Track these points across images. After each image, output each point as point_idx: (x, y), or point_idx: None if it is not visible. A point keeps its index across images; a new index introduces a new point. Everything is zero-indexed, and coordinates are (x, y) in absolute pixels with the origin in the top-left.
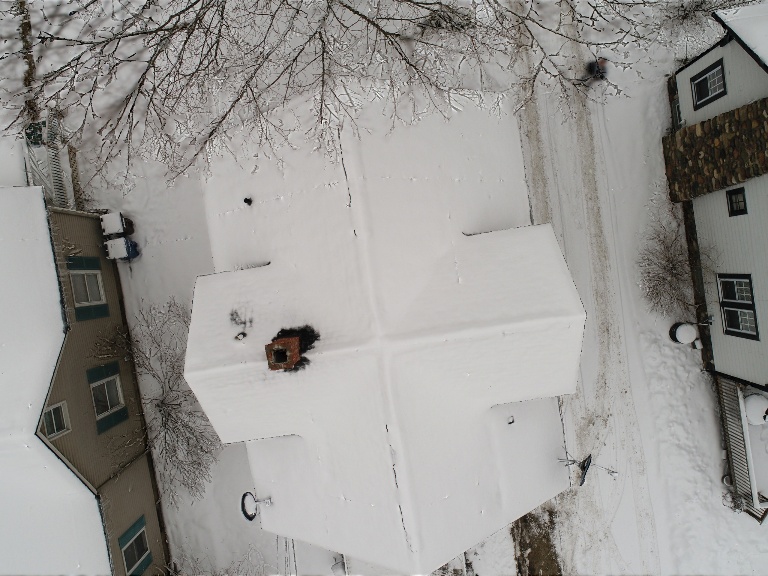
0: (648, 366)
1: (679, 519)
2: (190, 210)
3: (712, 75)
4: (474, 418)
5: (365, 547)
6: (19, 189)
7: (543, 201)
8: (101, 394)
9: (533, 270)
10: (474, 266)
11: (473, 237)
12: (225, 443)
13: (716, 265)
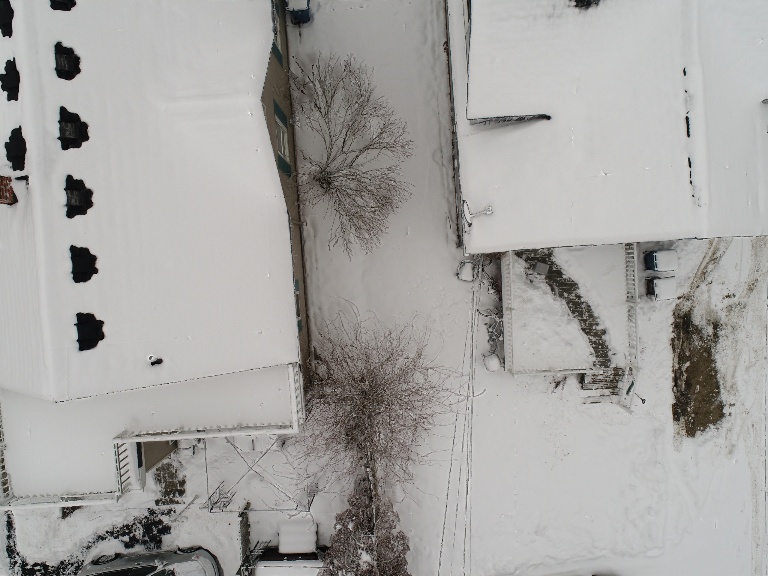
0: None
1: None
2: None
3: None
4: (748, 104)
5: (628, 220)
6: None
7: None
8: None
9: None
10: None
11: None
12: (470, 118)
13: None
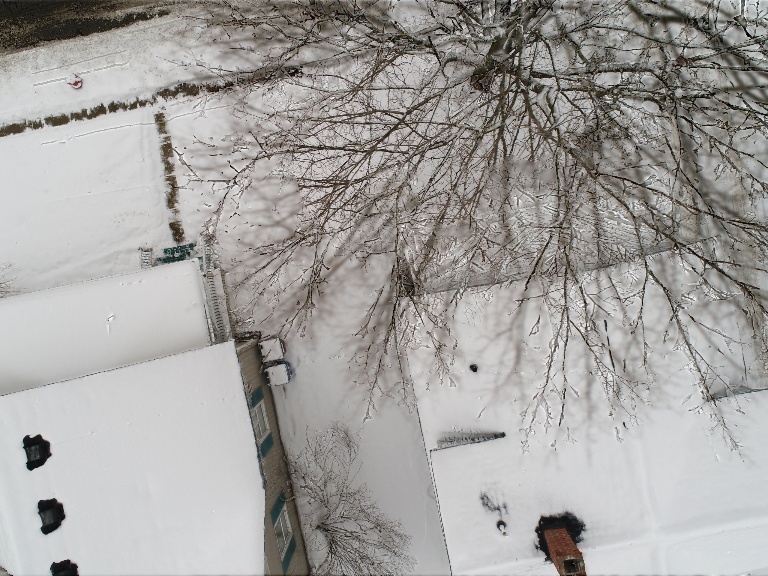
0: None
1: None
2: (343, 328)
3: None
4: None
5: None
6: (216, 347)
7: None
8: (277, 529)
9: None
10: None
11: None
12: None
13: None
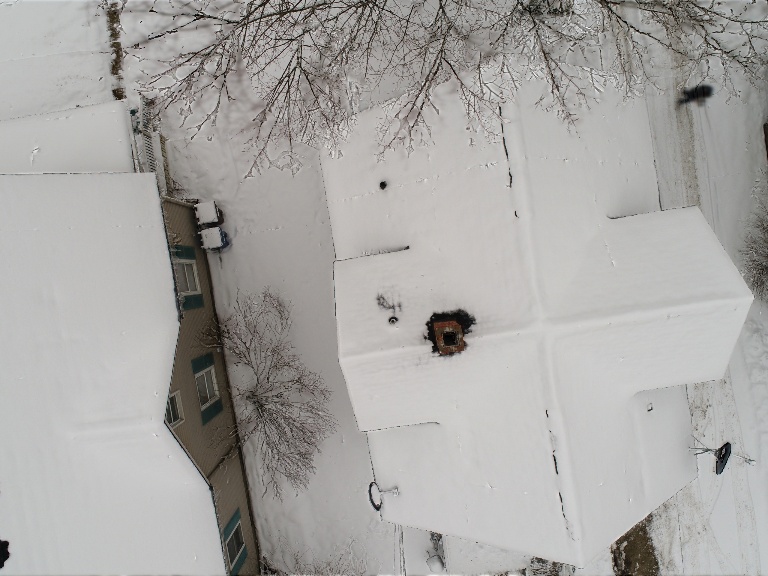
0: (749, 356)
1: None
2: (281, 199)
3: None
4: (621, 404)
5: (515, 536)
6: (135, 175)
7: None
8: (201, 385)
9: (690, 252)
10: (626, 249)
11: (619, 220)
12: None
13: None
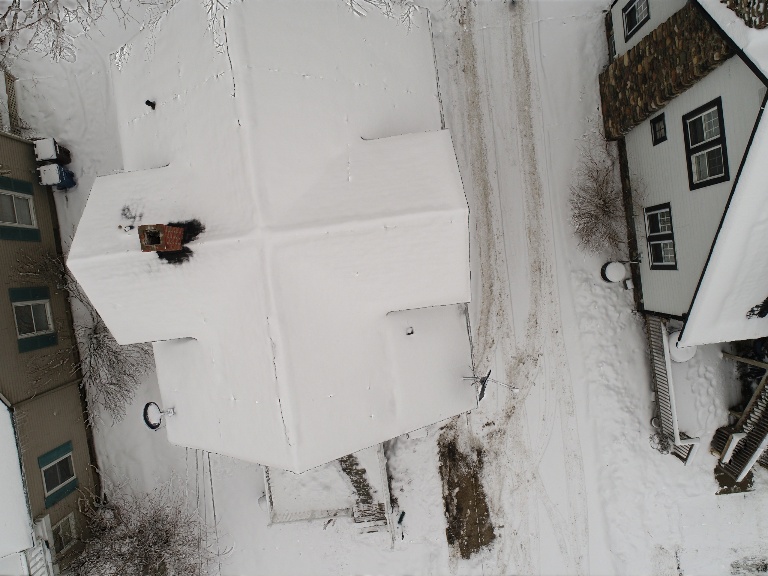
0: (579, 305)
1: (607, 460)
2: None
3: (639, 2)
4: (367, 322)
5: (251, 446)
6: None
7: (478, 137)
8: (27, 316)
9: (423, 169)
10: (366, 166)
11: (370, 141)
12: None
13: (642, 198)
